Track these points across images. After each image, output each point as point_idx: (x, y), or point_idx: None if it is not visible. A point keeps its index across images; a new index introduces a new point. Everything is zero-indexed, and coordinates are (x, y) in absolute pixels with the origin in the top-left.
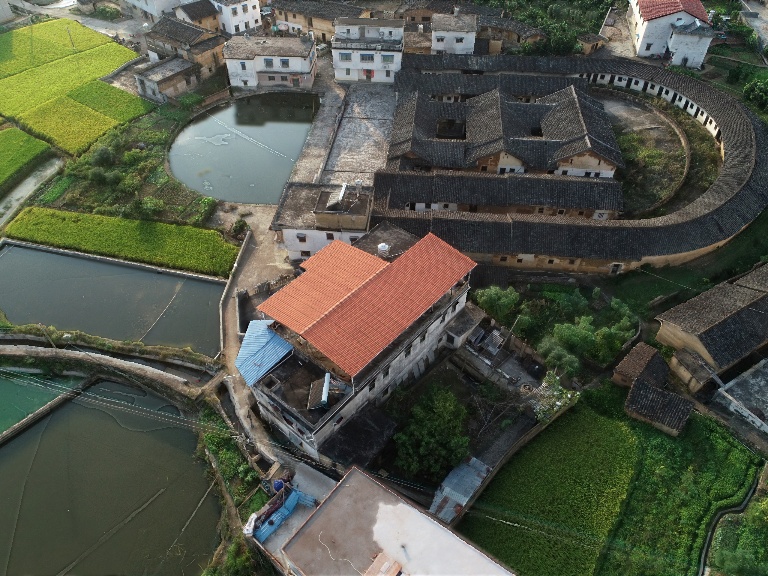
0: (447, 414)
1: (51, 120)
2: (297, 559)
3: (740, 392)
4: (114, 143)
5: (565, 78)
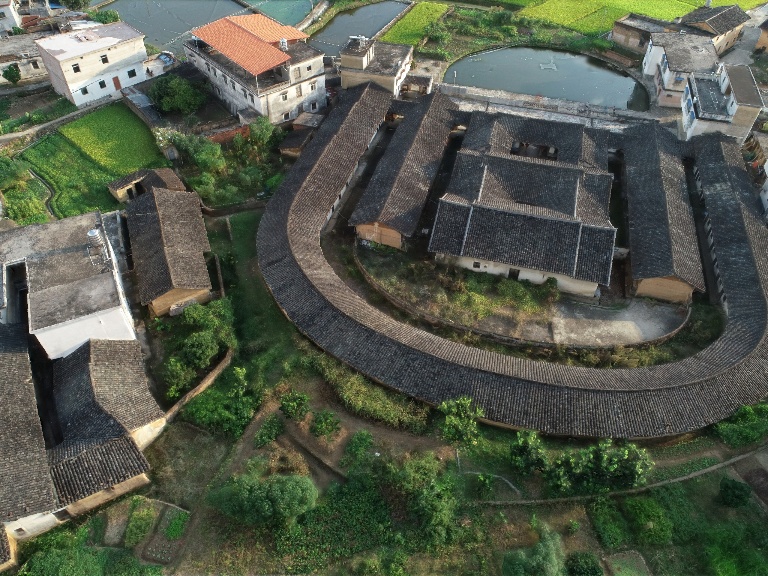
0: (172, 85)
1: (564, 4)
2: (116, 24)
3: (111, 226)
4: (520, 19)
5: (670, 250)
